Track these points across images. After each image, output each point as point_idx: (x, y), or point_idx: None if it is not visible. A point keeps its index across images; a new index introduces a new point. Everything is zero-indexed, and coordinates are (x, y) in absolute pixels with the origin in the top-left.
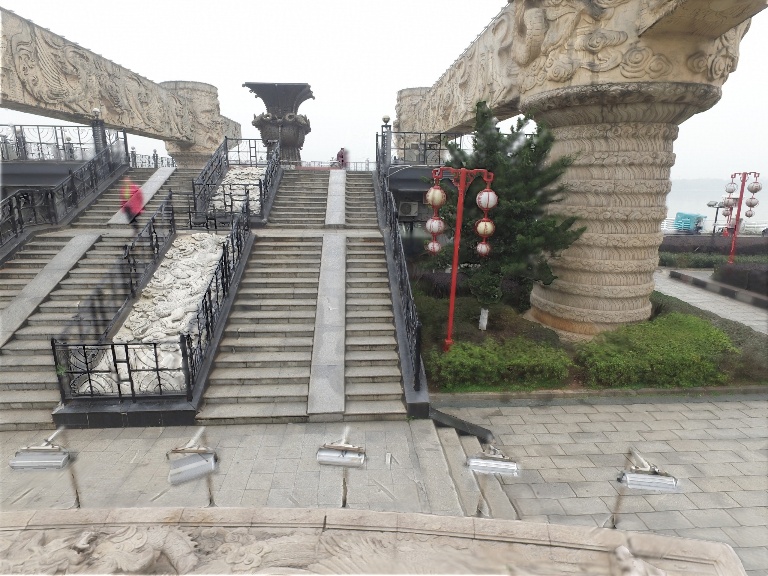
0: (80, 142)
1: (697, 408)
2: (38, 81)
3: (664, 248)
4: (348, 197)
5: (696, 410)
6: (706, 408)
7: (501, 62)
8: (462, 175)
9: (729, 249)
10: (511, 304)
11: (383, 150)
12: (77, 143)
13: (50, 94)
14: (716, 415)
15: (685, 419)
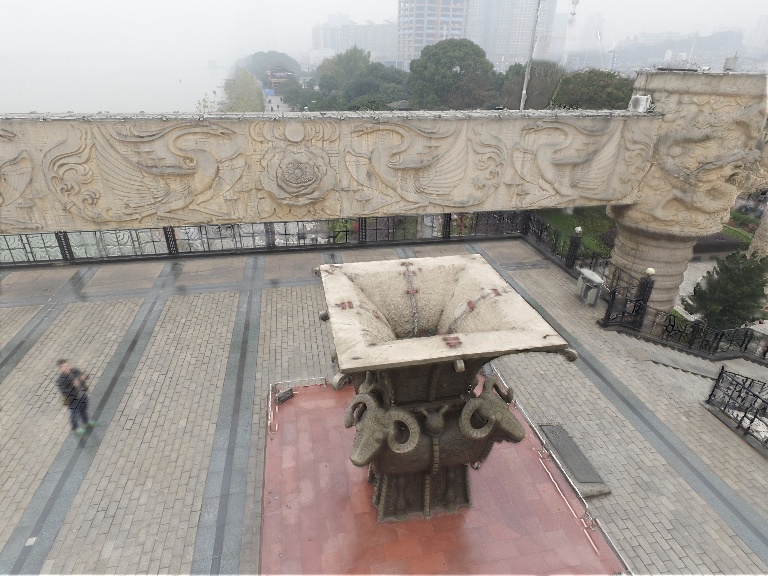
0: None
1: None
2: None
3: None
4: None
5: None
6: None
7: (559, 171)
8: None
9: None
10: None
11: (645, 303)
12: None
13: None
14: None
15: None
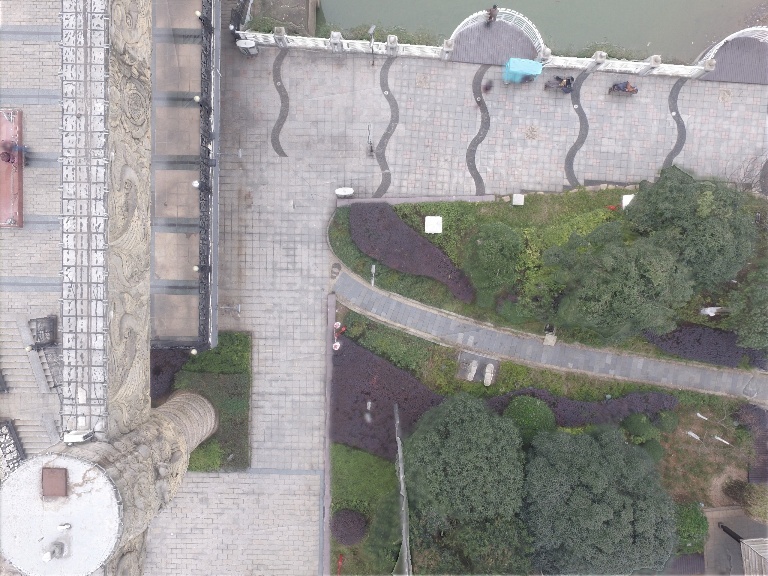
0: None
1: (200, 476)
2: None
3: (357, 246)
4: (43, 362)
5: (199, 477)
6: (203, 476)
7: None
8: None
9: (397, 270)
10: (164, 394)
11: None
12: None
13: None
14: (203, 481)
15: (191, 482)
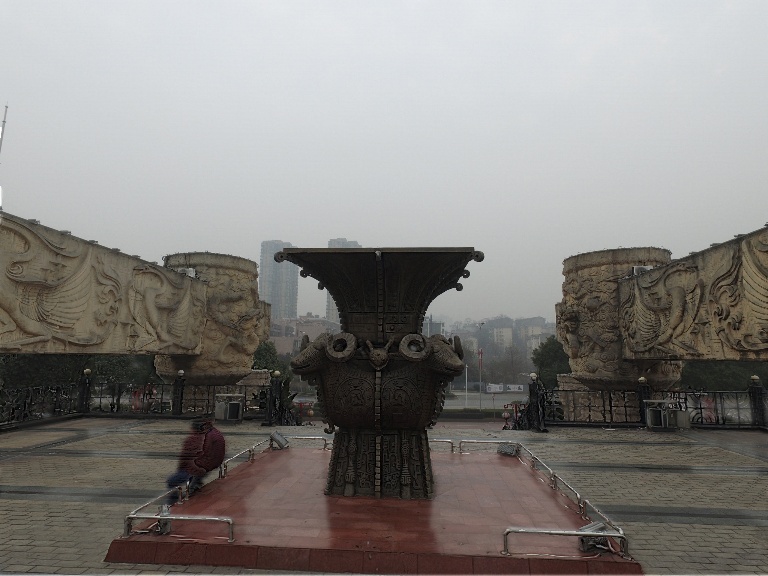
0: (553, 404)
1: None
2: (745, 320)
3: None
4: None
5: None
6: None
7: (160, 315)
8: (302, 405)
9: None
10: None
11: None
12: (556, 405)
13: (761, 335)
14: None
15: None
